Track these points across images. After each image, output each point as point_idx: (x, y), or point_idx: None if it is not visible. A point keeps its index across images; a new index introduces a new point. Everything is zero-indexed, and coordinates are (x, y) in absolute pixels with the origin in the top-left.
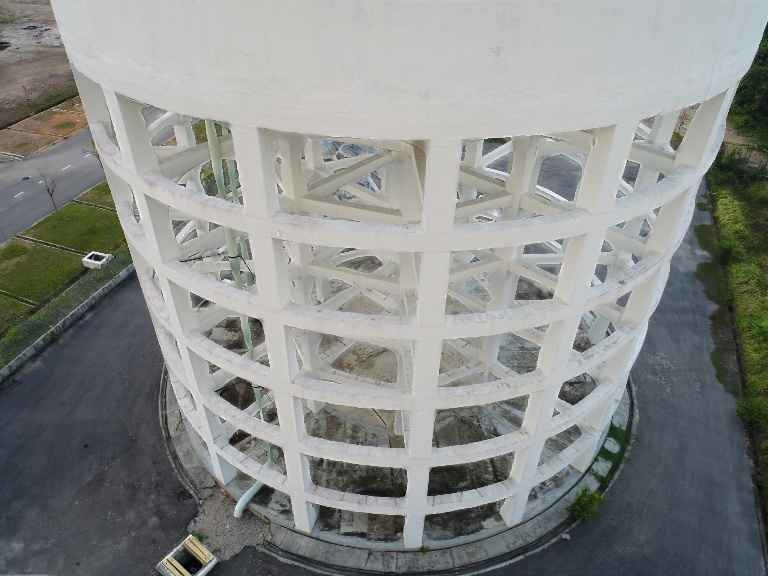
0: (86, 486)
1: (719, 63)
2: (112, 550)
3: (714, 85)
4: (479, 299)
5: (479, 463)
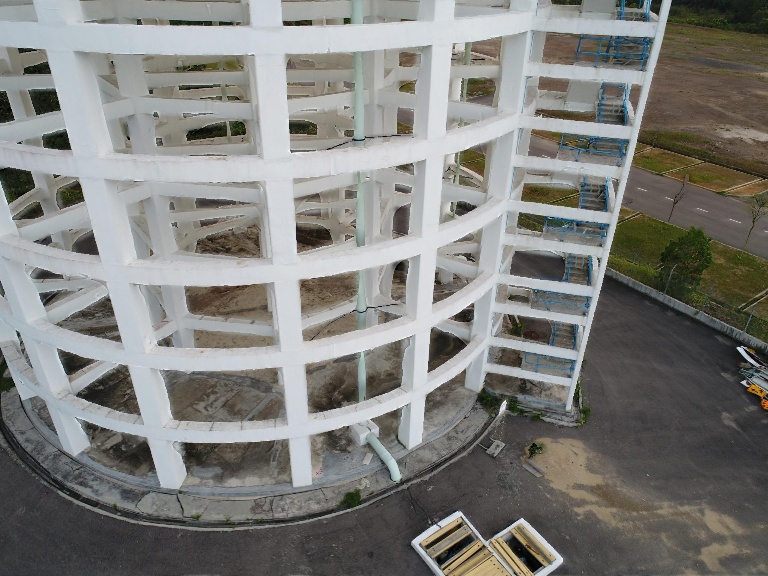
0: None
1: None
2: None
3: None
4: None
5: None
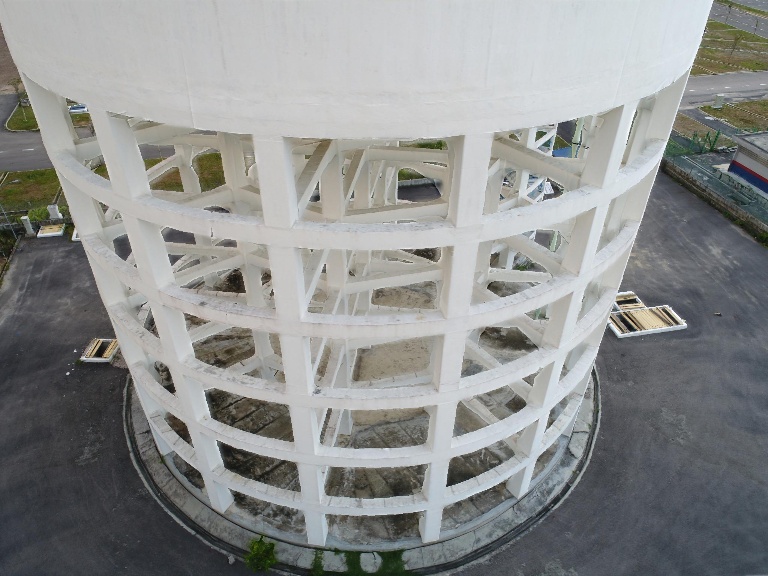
0: None
1: (195, 90)
2: (100, 317)
3: (200, 115)
4: None
5: (269, 458)
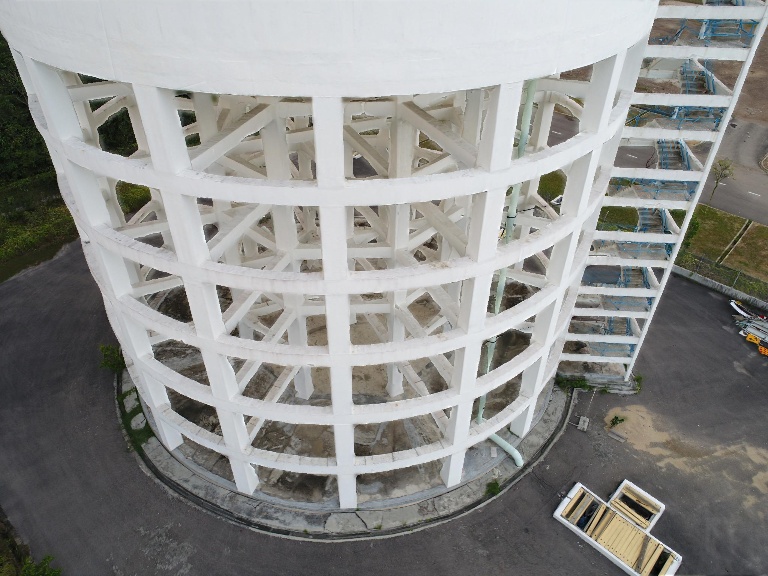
0: None
1: None
2: None
3: None
4: (255, 259)
5: None
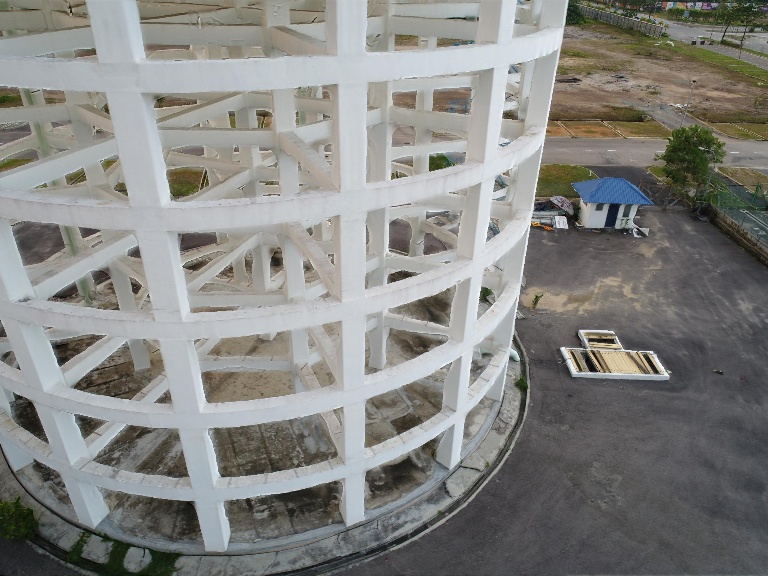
0: None
1: None
2: None
3: None
4: (192, 280)
5: None
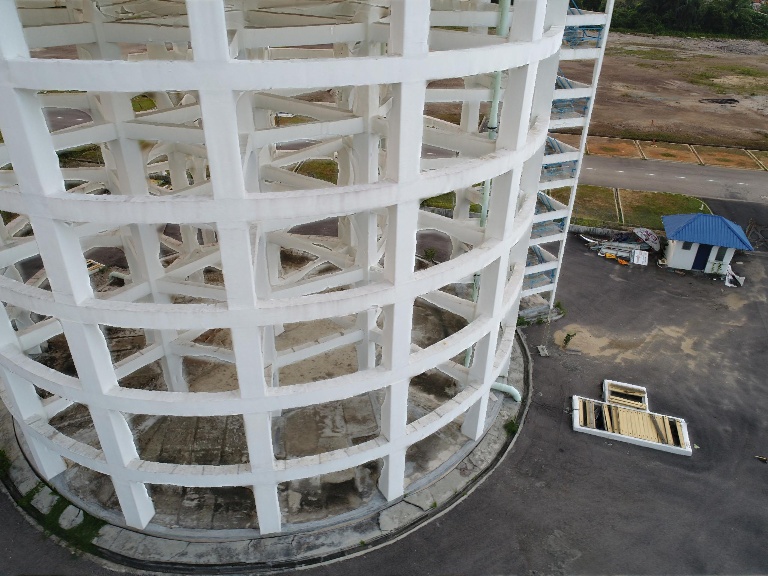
0: (165, 232)
1: None
2: None
3: None
4: (178, 267)
5: None
